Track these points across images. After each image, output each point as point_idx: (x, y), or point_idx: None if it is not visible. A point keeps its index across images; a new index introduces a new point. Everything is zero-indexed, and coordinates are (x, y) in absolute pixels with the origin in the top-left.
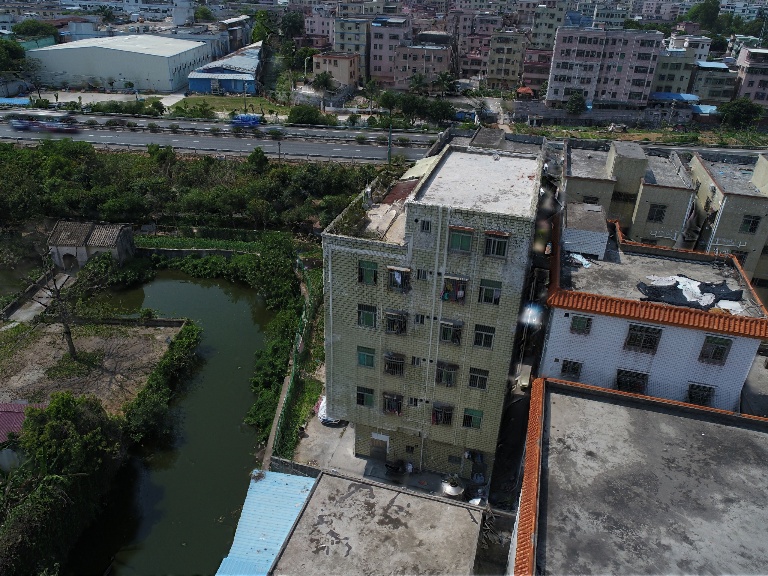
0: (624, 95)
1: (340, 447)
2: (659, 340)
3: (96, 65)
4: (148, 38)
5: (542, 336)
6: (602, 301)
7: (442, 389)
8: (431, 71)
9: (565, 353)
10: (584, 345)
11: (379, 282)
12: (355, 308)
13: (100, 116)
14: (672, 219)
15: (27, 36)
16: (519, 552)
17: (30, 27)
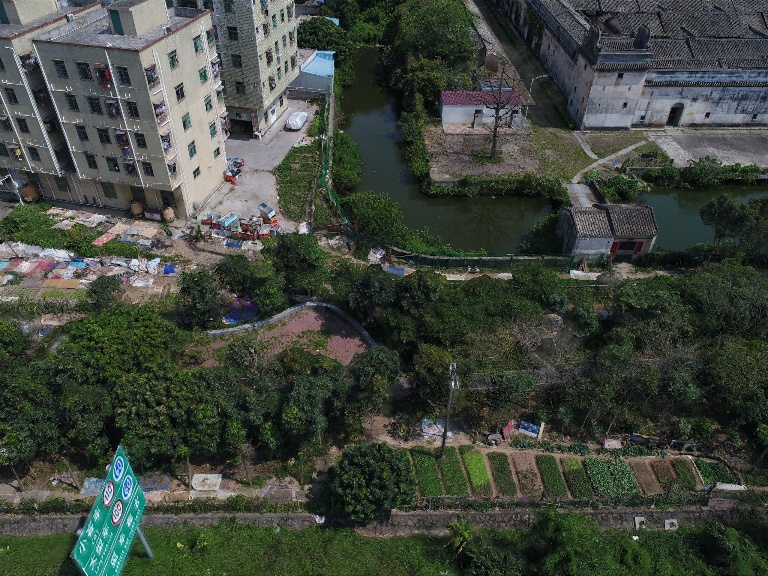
0: None
1: (295, 110)
2: None
3: None
4: None
5: None
6: None
7: None
8: None
9: None
10: None
11: None
12: None
13: None
14: None
15: None
16: None
17: None
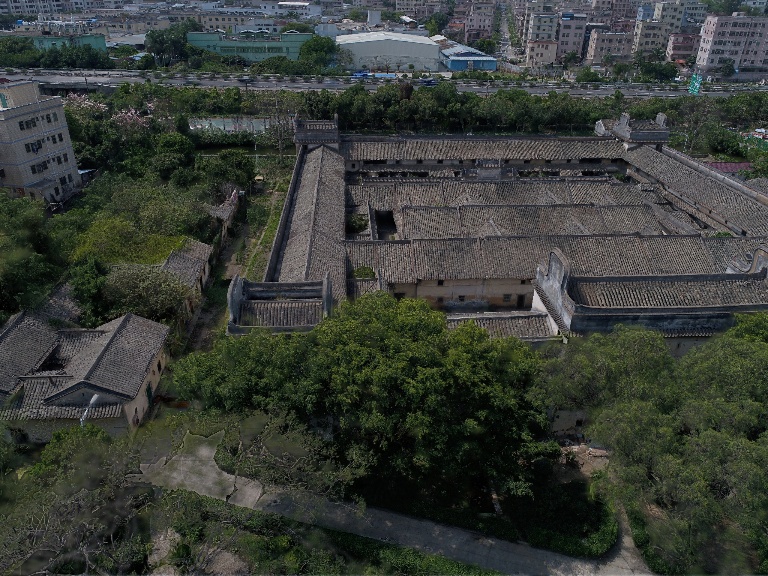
0: (760, 62)
1: None
2: None
3: (386, 53)
4: None
5: None
6: None
7: None
8: (621, 50)
9: None
10: None
11: None
12: None
13: None
14: None
15: None
16: None
17: (300, 28)
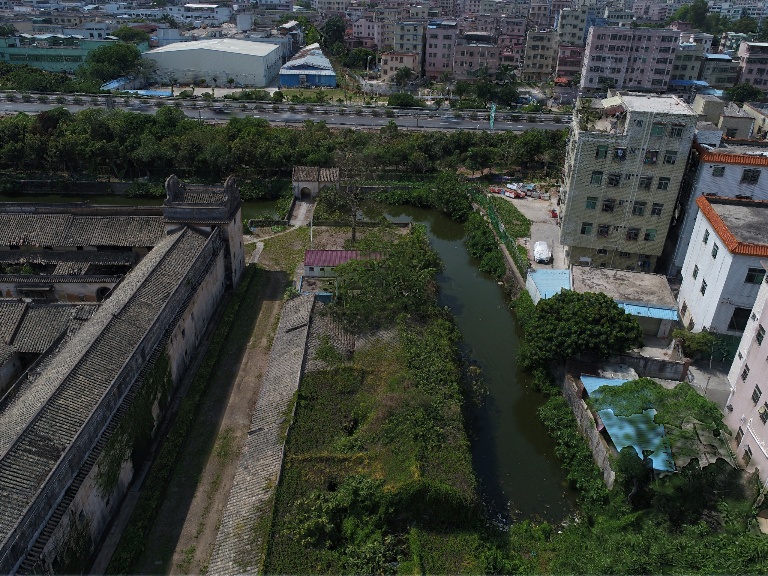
0: (648, 82)
1: None
2: (759, 176)
3: (201, 64)
4: (232, 41)
5: (689, 187)
6: (731, 157)
7: (635, 218)
8: (485, 65)
9: (708, 189)
10: (719, 183)
11: (607, 157)
12: (590, 173)
13: (239, 103)
14: (740, 137)
15: (129, 41)
16: (724, 237)
17: (128, 33)
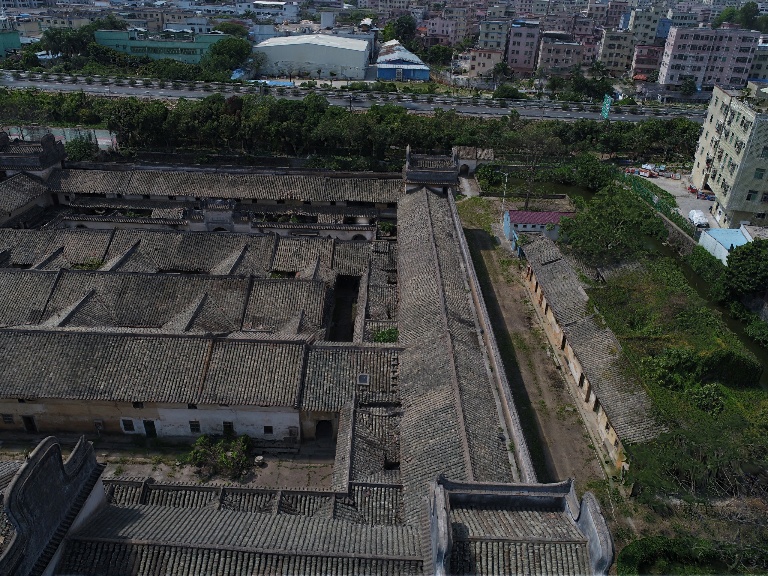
0: (726, 80)
1: None
2: None
3: (306, 58)
4: (326, 37)
5: None
6: None
7: None
8: (570, 62)
9: None
10: None
11: None
12: (762, 149)
13: (360, 93)
14: None
15: None
16: None
17: (230, 28)
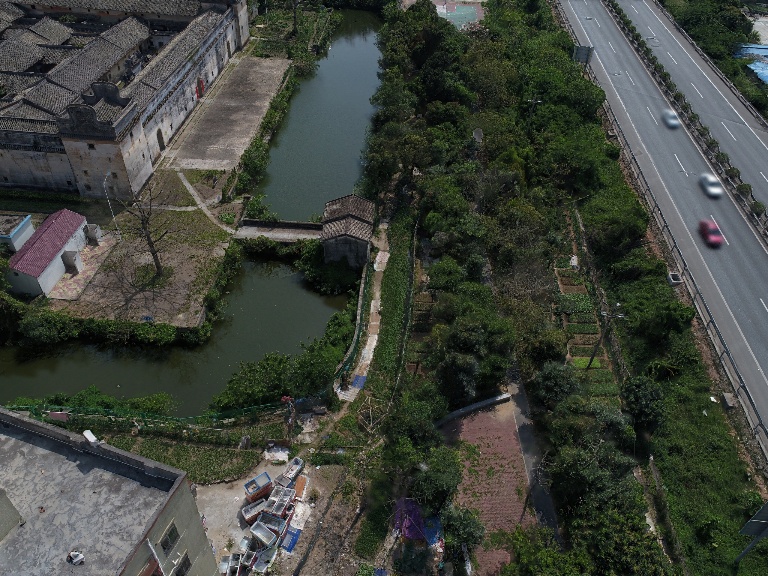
0: None
1: None
2: None
3: None
4: None
5: None
6: None
7: None
8: None
9: None
10: None
11: None
12: None
13: None
14: None
15: None
16: None
17: None
